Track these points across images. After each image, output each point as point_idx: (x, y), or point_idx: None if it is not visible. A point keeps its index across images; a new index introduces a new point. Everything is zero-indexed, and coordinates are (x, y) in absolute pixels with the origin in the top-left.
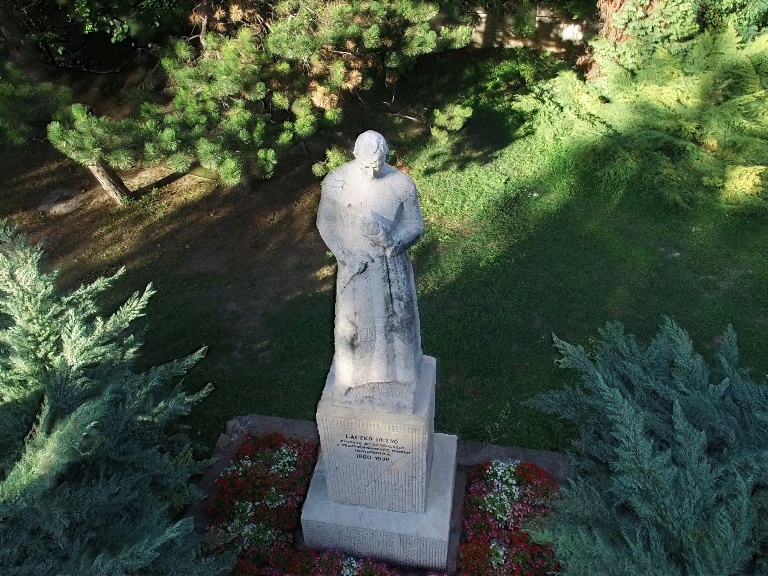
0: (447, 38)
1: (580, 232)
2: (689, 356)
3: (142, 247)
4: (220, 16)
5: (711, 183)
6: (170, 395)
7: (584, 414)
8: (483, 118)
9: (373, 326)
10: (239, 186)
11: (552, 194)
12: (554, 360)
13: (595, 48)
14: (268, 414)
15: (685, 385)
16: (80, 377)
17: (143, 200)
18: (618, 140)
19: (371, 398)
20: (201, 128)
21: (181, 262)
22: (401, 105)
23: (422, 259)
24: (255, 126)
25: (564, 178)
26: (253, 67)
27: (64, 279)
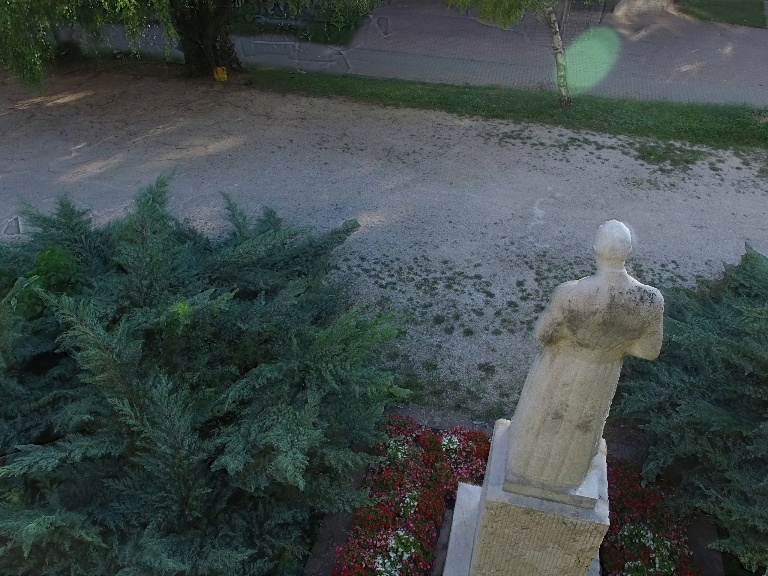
0: None
1: None
2: None
3: None
4: None
5: None
6: None
7: None
8: None
9: None
10: None
11: None
12: None
13: None
14: None
15: None
16: None
17: None
18: None
19: None
20: None
21: None
22: None
23: None
24: None
25: None
26: None
27: None
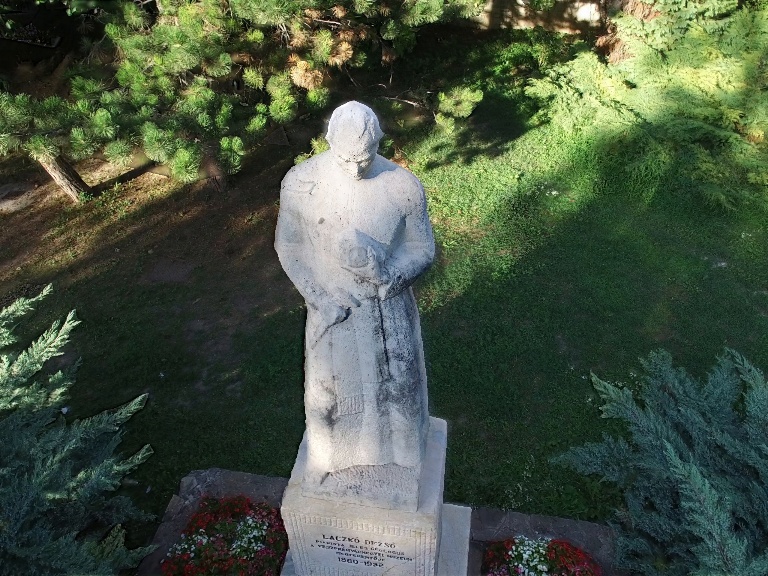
0: (456, 5)
1: (608, 237)
2: (766, 404)
3: (98, 252)
4: None
5: (758, 181)
6: (104, 452)
7: (631, 475)
8: (492, 105)
9: (360, 395)
10: (213, 181)
11: (573, 192)
12: (587, 400)
13: (619, 26)
14: (235, 466)
15: (761, 441)
16: None
17: (103, 197)
18: (649, 130)
19: (358, 489)
20: (149, 110)
21: (142, 271)
22: (400, 88)
23: None
24: (219, 109)
25: (586, 174)
26: (216, 35)
27: None
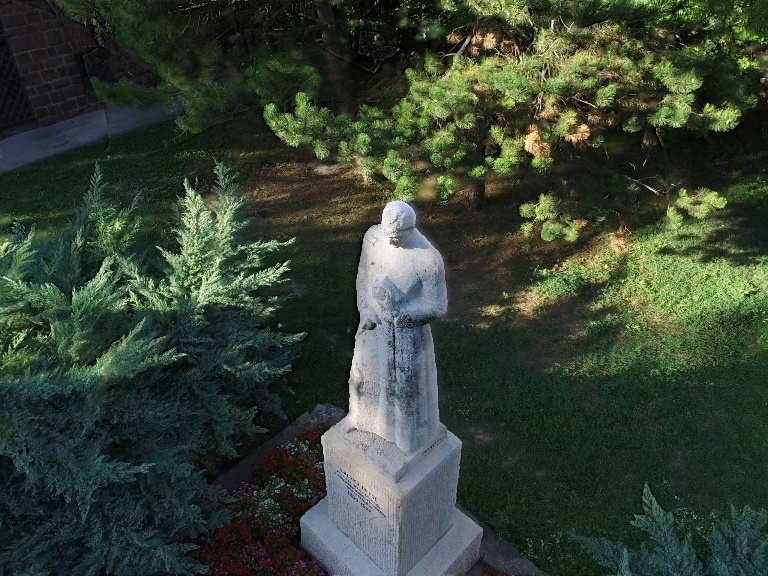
0: (709, 117)
1: None
2: None
3: (359, 225)
4: (477, 41)
5: None
6: (275, 359)
7: None
8: None
9: (378, 383)
10: (466, 200)
11: None
12: None
13: None
14: None
15: None
16: (200, 314)
17: None
18: None
19: (367, 447)
20: (401, 141)
21: None
22: (652, 172)
23: (595, 338)
24: (454, 153)
25: None
26: None
27: (249, 231)
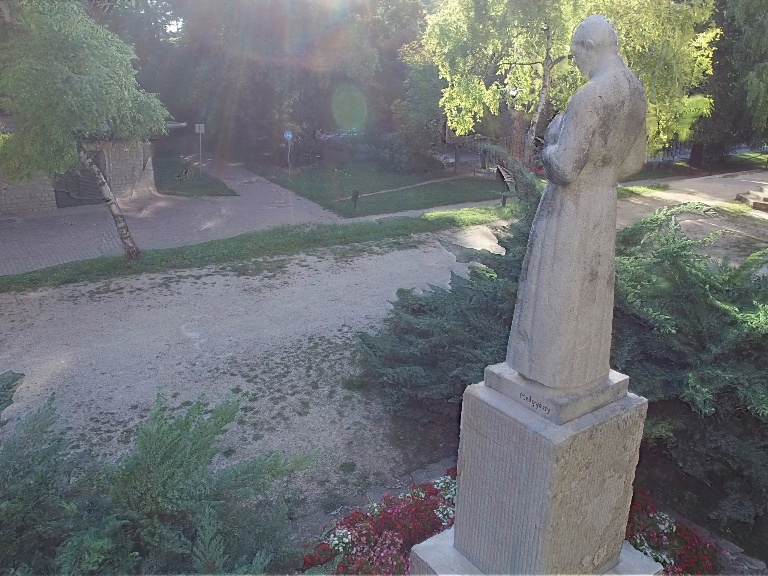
0: None
1: None
2: None
3: None
4: None
5: None
6: None
7: None
8: None
9: None
10: None
11: None
12: None
13: None
14: None
15: None
16: None
17: None
18: None
19: None
20: None
21: None
22: None
23: None
24: None
25: None
26: None
27: None
